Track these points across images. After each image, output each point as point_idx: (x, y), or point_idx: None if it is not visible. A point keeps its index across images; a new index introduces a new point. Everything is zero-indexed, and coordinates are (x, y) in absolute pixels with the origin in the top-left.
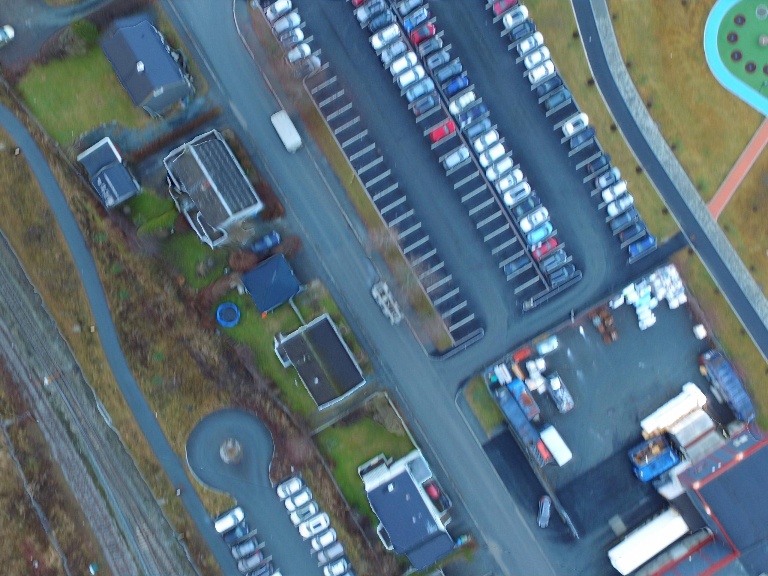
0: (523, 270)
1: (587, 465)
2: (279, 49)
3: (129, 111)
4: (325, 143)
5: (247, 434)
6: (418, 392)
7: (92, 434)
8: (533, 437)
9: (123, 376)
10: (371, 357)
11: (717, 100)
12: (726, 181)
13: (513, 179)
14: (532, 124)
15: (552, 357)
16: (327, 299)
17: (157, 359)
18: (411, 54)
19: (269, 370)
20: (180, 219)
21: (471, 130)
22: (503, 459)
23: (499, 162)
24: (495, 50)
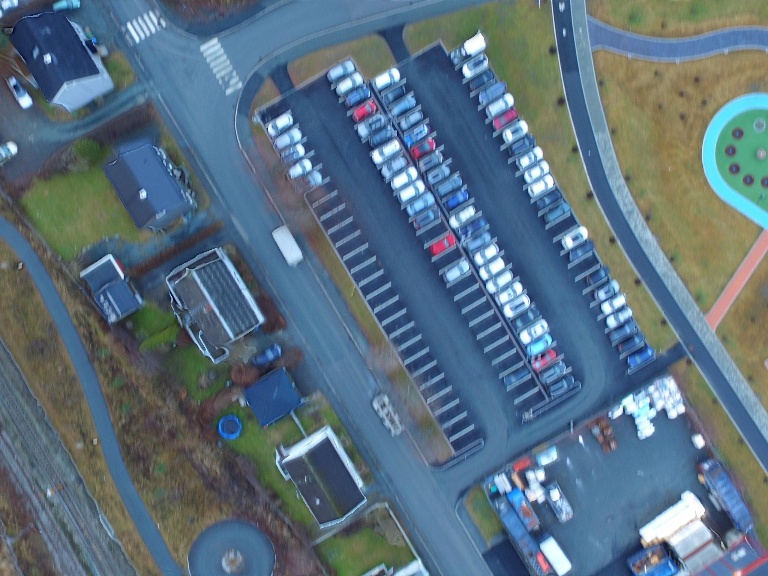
0: (523, 381)
1: (586, 572)
2: (280, 164)
3: (131, 225)
4: (326, 256)
5: (249, 545)
6: (418, 502)
7: (95, 545)
8: (533, 549)
9: (125, 488)
10: (372, 467)
11: (715, 213)
12: (724, 292)
13: (513, 292)
14: (532, 237)
15: (551, 466)
16: (328, 410)
17: (159, 471)
18: (411, 169)
19: (270, 481)
20: (182, 334)
21: (471, 244)
22: (503, 568)
23: (499, 276)
24: (495, 164)
